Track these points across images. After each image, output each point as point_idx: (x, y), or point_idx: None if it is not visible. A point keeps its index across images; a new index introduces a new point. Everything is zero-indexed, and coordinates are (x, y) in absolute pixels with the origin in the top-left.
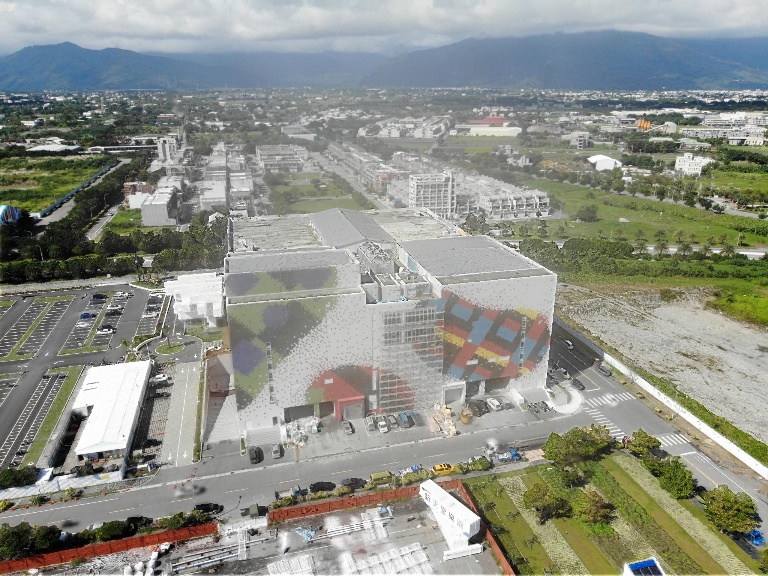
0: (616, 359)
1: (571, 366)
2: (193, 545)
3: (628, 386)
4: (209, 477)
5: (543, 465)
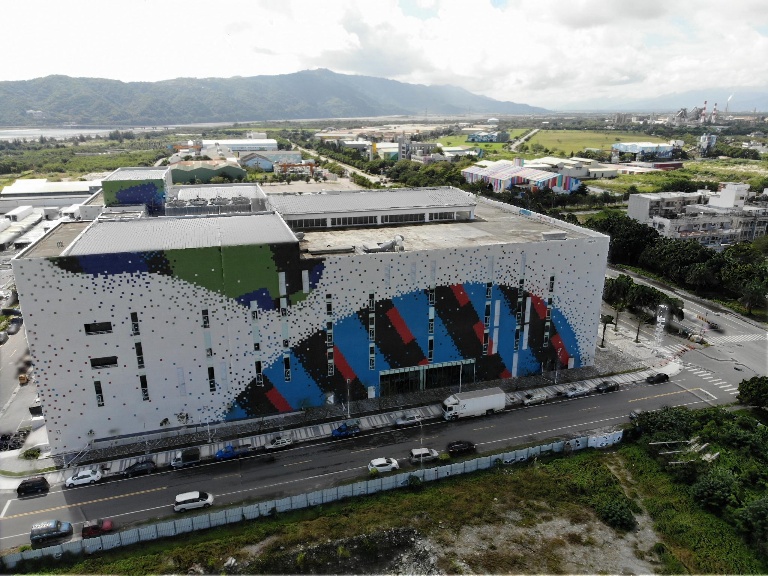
0: (84, 568)
1: (108, 495)
2: None
3: None
4: None
5: None
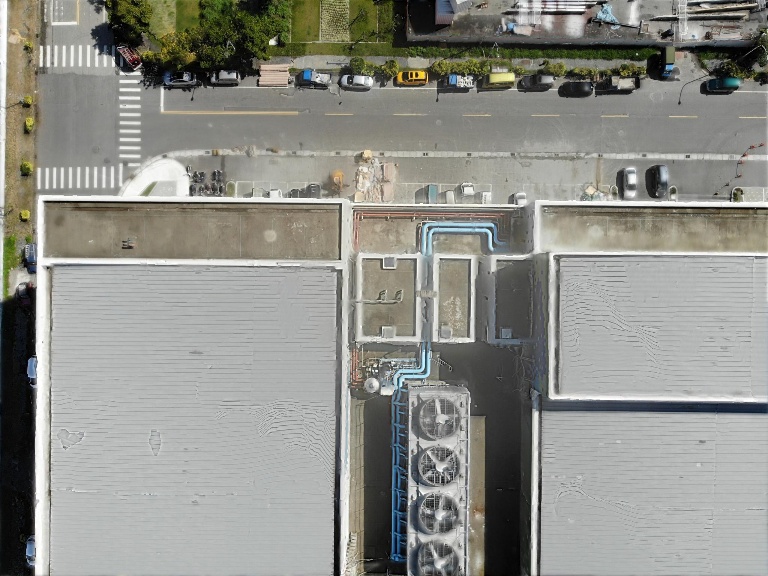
0: None
1: None
2: (735, 35)
3: (25, 204)
4: (719, 156)
5: (277, 52)
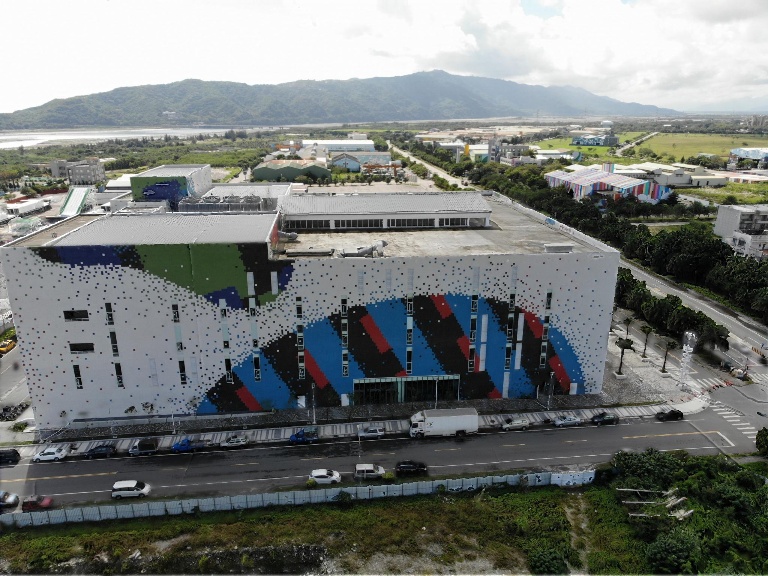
0: (9, 540)
1: (63, 473)
2: None
3: None
4: None
5: None
